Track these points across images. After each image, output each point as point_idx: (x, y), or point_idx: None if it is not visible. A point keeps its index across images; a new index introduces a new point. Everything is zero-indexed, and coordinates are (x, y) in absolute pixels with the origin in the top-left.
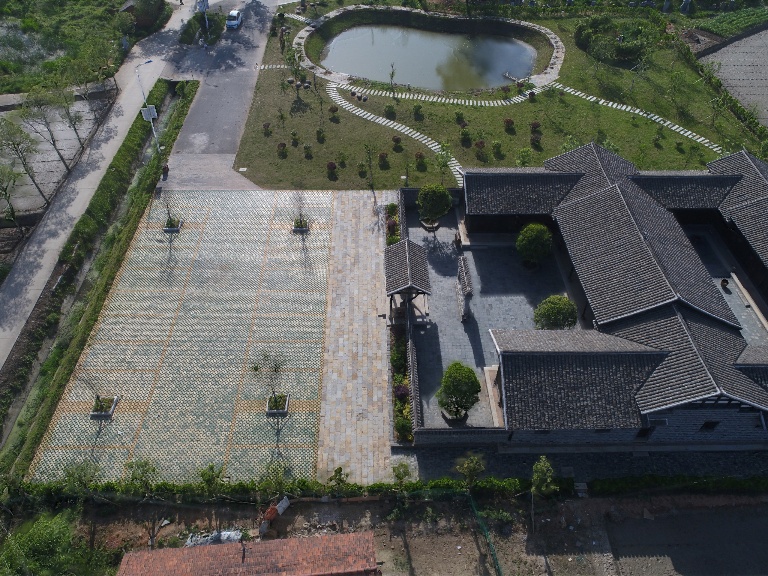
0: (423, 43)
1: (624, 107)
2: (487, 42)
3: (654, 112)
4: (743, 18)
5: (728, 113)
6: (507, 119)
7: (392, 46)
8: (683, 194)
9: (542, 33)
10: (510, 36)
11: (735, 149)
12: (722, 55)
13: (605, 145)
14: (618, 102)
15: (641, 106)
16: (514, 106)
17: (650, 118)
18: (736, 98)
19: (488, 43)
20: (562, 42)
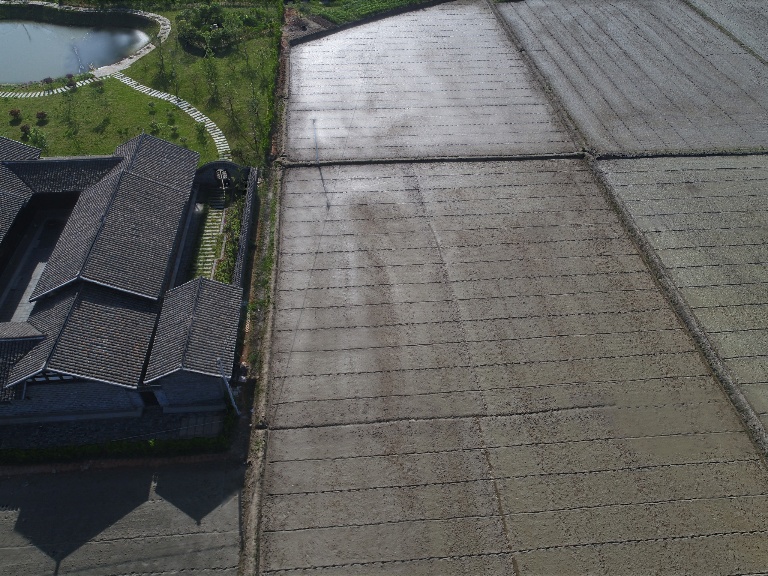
0: (66, 37)
1: (162, 95)
2: (107, 34)
3: (188, 99)
4: (370, 5)
5: (264, 98)
6: (12, 110)
7: (48, 41)
8: (57, 178)
9: (158, 24)
10: (135, 28)
11: (232, 133)
12: (322, 41)
13: (30, 132)
14: (161, 90)
15: (180, 93)
16: (49, 97)
17: (177, 105)
18: (291, 83)
19: (107, 35)
20: (169, 32)
